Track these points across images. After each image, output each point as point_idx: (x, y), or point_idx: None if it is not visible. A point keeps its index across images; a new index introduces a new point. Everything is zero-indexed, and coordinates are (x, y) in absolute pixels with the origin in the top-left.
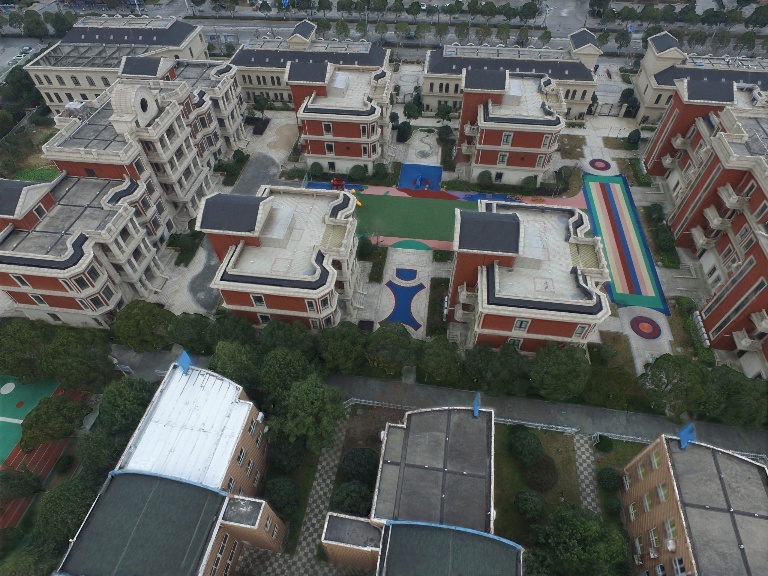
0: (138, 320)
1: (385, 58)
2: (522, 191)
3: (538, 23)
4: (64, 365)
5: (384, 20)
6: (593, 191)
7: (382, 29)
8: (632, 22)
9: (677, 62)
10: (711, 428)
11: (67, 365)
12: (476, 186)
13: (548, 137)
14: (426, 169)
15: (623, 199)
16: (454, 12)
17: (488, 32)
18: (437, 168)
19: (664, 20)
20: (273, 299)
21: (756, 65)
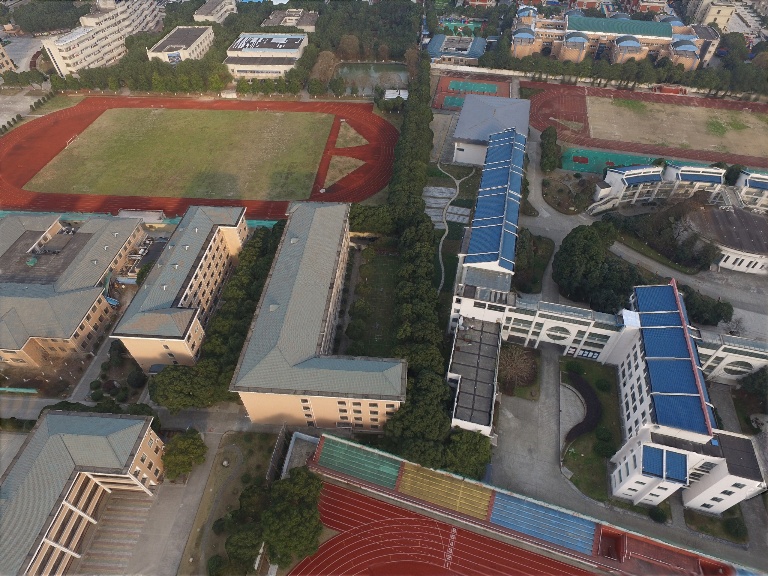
0: (505, 5)
1: None
2: None
3: None
4: (496, 7)
5: None
6: (603, 6)
7: None
8: None
9: None
10: None
11: (497, 7)
12: None
13: None
14: None
15: (612, 7)
16: None
17: None
18: (557, 2)
19: None
20: (534, 1)
21: None
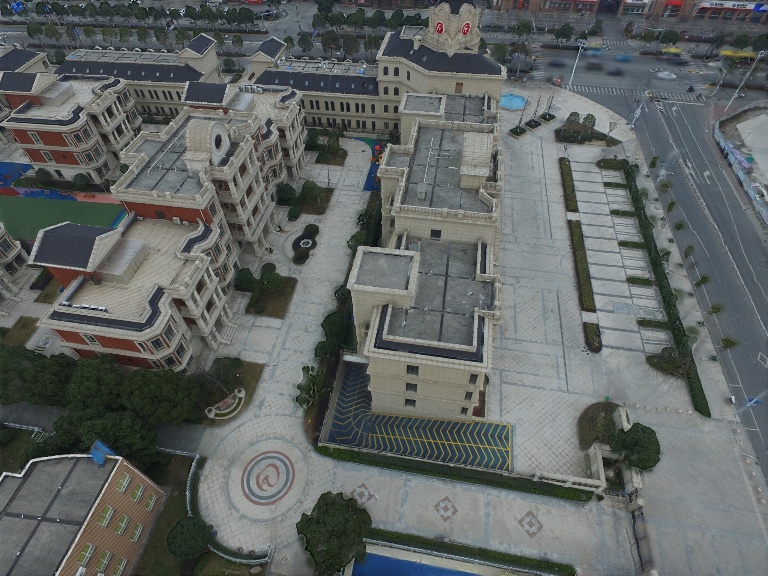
0: None
1: (29, 61)
2: (78, 188)
3: (267, 28)
4: None
5: (120, 25)
6: None
7: (88, 33)
8: (338, 27)
9: (270, 65)
10: (32, 404)
11: None
12: (40, 183)
13: (67, 136)
14: (17, 167)
15: None
16: (177, 17)
17: (183, 36)
18: (28, 166)
19: (367, 25)
20: None
21: (342, 68)
